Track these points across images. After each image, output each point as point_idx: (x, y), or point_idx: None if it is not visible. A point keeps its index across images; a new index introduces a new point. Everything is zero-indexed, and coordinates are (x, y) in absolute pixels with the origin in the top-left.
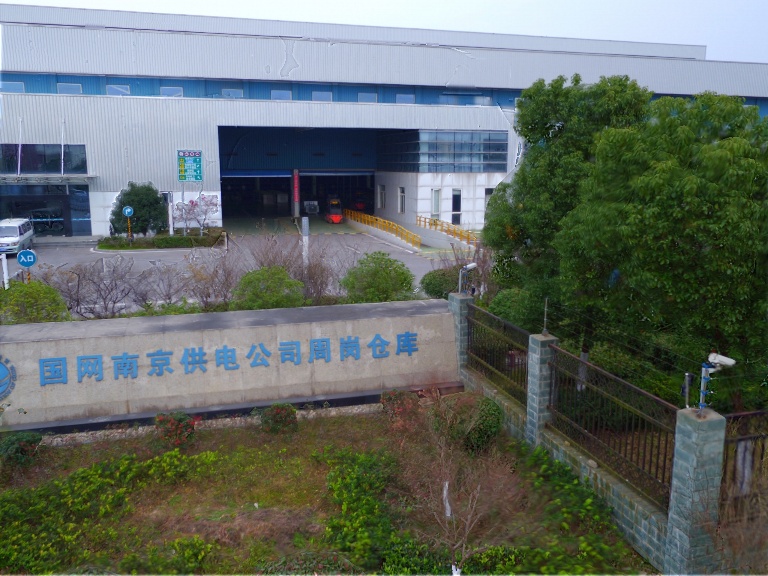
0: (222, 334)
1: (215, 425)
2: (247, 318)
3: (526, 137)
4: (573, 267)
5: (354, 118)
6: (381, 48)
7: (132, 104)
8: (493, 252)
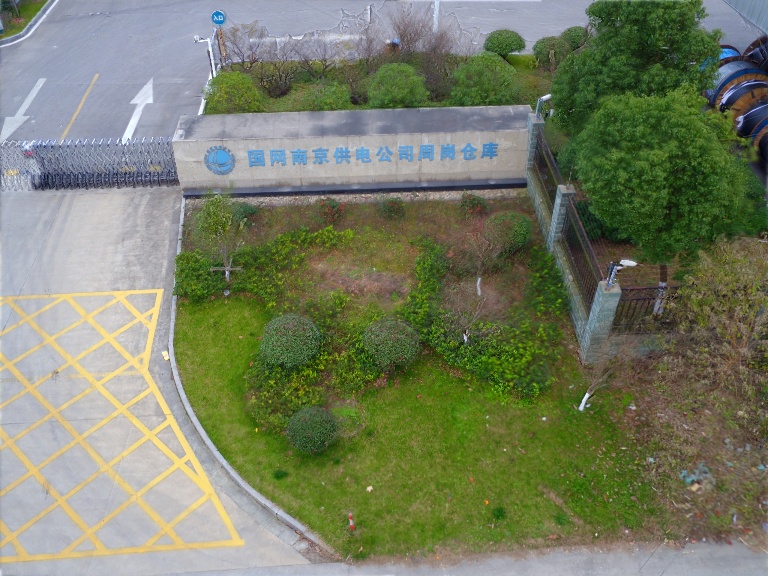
0: (360, 139)
1: (355, 200)
2: (378, 122)
3: None
4: None
5: None
6: None
7: None
8: None
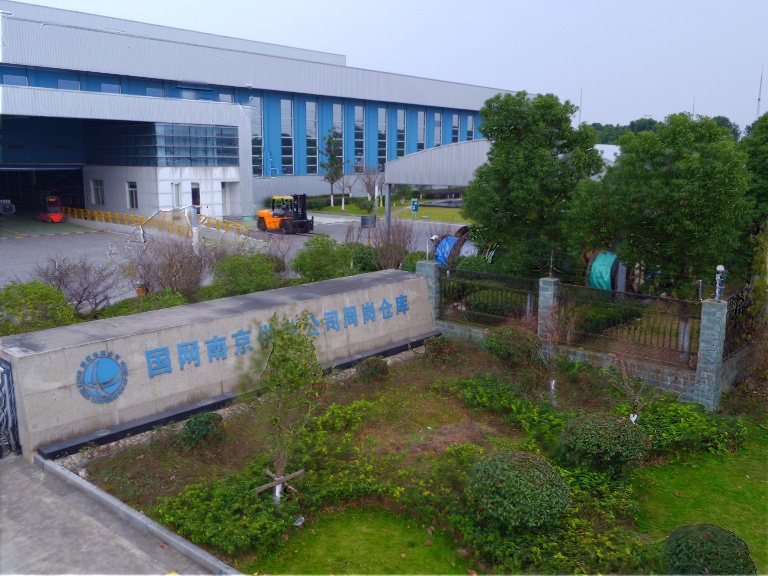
0: (284, 310)
1: None
2: (281, 296)
3: (486, 136)
4: (592, 226)
5: (86, 108)
6: (84, 33)
7: None
8: (470, 224)
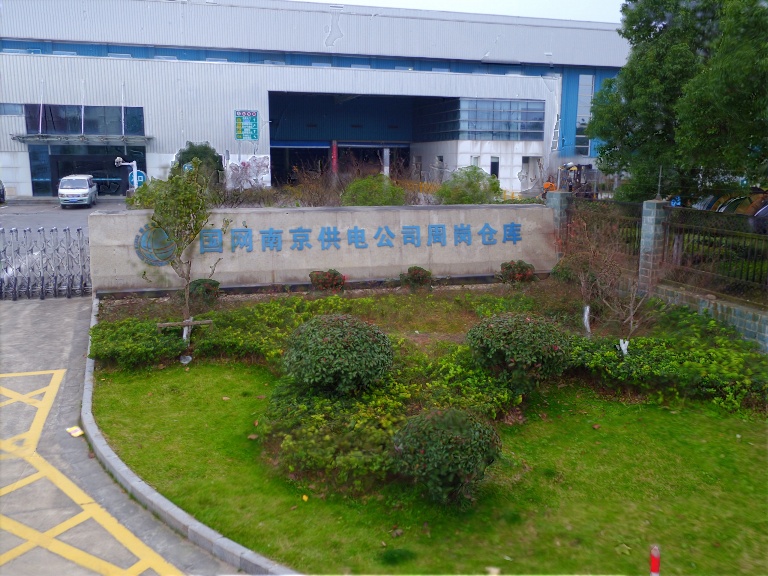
0: (353, 216)
1: None
2: (369, 208)
3: (629, 39)
4: (695, 126)
5: (398, 85)
6: (419, 22)
7: (188, 68)
8: (597, 144)
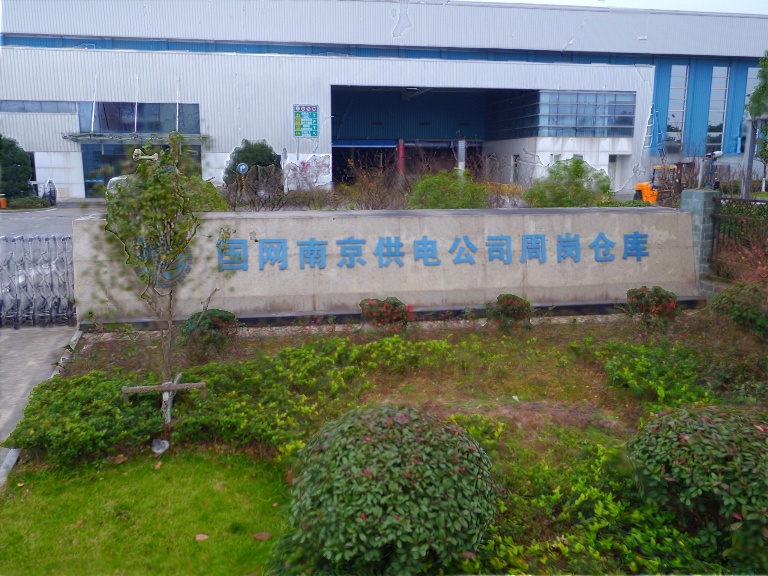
0: (422, 222)
1: (418, 326)
2: (442, 212)
3: None
4: None
5: (471, 77)
6: (494, 10)
7: (246, 62)
8: (764, 123)
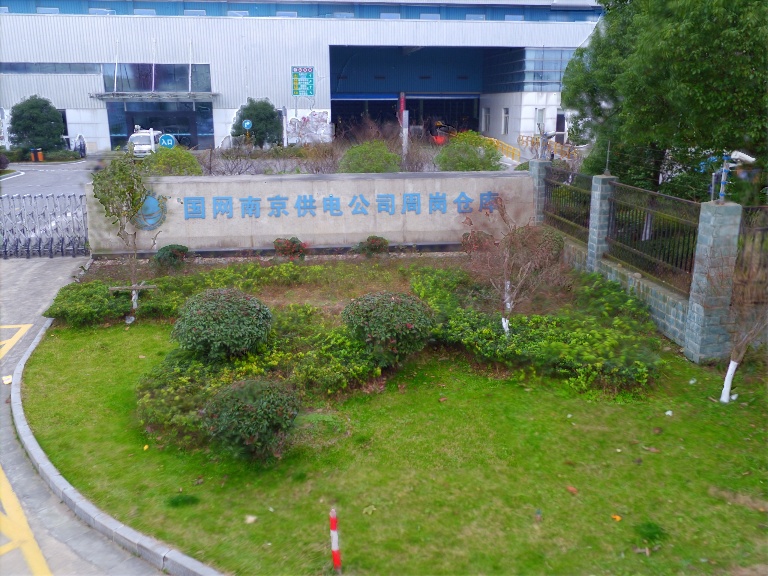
0: (329, 185)
1: (322, 258)
2: (350, 176)
3: (605, 5)
4: (630, 103)
5: (460, 36)
6: None
7: (251, 25)
8: (569, 114)
